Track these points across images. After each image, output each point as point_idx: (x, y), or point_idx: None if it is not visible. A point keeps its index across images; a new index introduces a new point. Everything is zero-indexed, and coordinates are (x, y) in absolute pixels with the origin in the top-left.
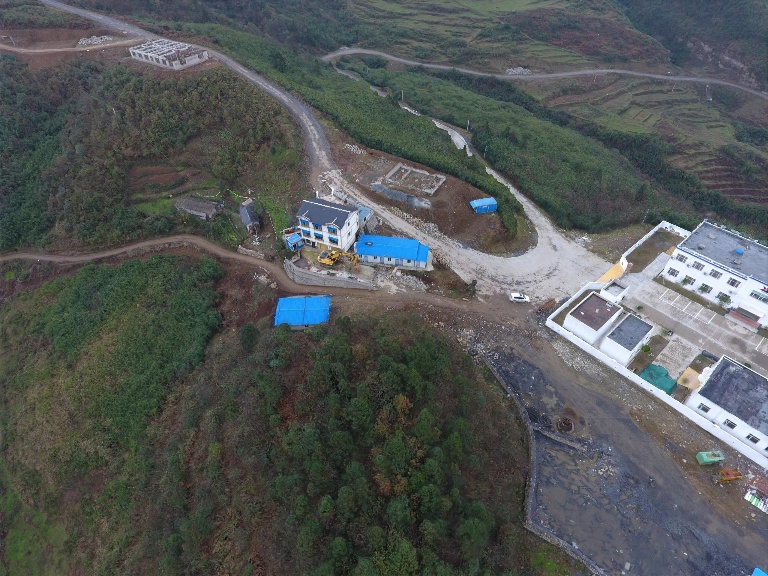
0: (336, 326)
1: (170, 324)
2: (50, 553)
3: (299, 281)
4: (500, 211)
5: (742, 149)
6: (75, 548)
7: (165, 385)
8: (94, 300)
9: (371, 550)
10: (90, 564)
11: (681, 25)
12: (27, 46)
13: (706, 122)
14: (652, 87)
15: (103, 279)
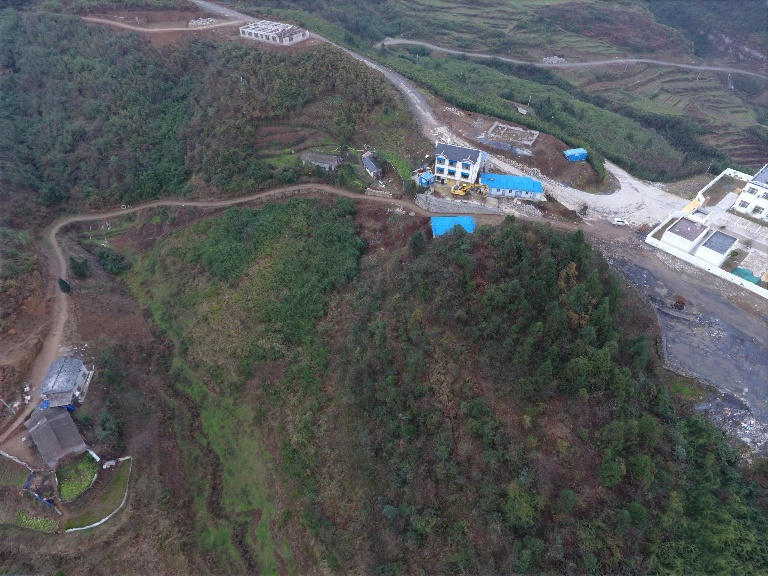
0: (506, 222)
1: (320, 249)
2: (241, 426)
3: (434, 210)
4: (589, 159)
5: (767, 129)
6: (266, 420)
7: (325, 295)
8: (244, 234)
9: (576, 356)
10: (283, 429)
11: (703, 19)
12: (145, 26)
13: (730, 108)
14: (678, 75)
15: (249, 217)
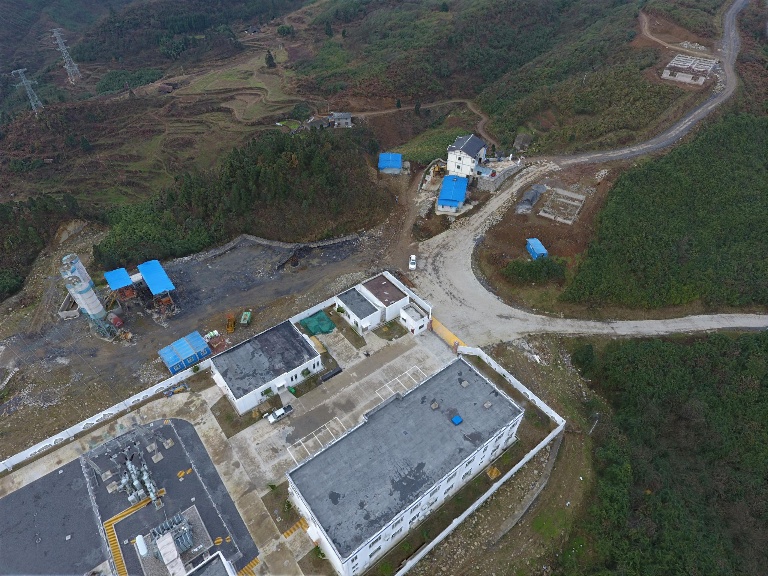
0: None
1: None
2: None
3: None
4: None
5: None
6: None
7: None
8: None
9: None
10: None
11: None
12: (656, 33)
13: None
14: None
15: None
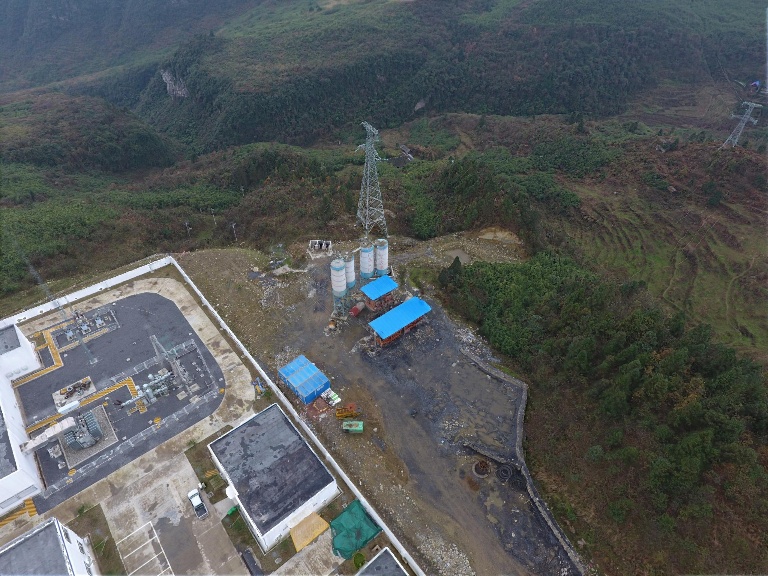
0: None
1: None
2: None
3: None
4: None
5: None
6: None
7: None
8: None
9: None
10: None
11: None
12: None
13: None
14: None
15: None
